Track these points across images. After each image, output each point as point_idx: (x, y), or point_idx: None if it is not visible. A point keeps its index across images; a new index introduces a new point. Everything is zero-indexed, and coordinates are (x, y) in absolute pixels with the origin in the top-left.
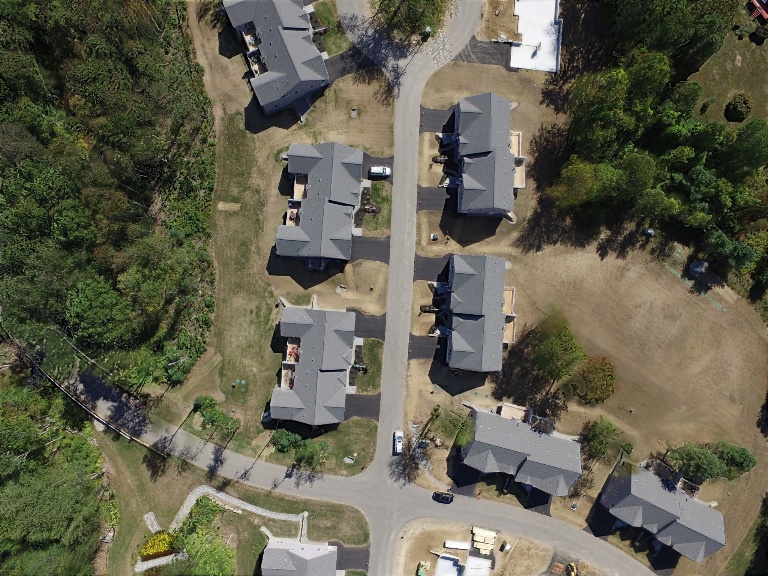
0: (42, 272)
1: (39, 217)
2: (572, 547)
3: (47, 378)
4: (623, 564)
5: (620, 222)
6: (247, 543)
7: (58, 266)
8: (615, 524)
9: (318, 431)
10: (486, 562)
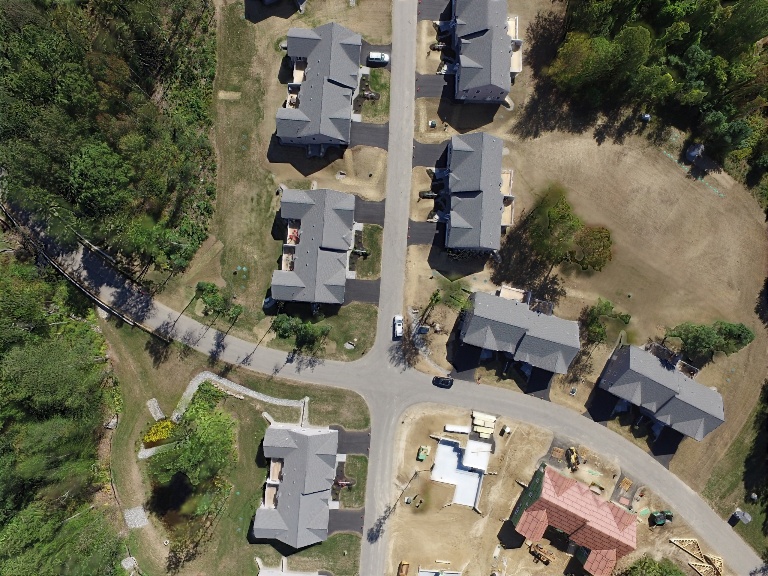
0: (46, 134)
1: (43, 81)
2: (572, 432)
3: (51, 265)
4: (623, 449)
5: (617, 108)
6: (249, 429)
7: (62, 129)
8: (614, 409)
9: (319, 316)
10: (486, 446)
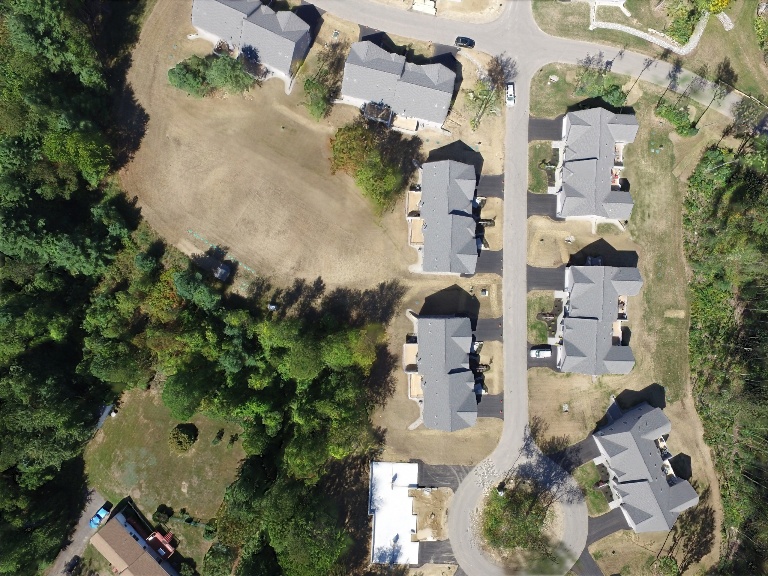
0: None
1: None
2: None
3: None
4: None
5: None
6: (642, 1)
7: None
8: None
9: (585, 105)
10: None
